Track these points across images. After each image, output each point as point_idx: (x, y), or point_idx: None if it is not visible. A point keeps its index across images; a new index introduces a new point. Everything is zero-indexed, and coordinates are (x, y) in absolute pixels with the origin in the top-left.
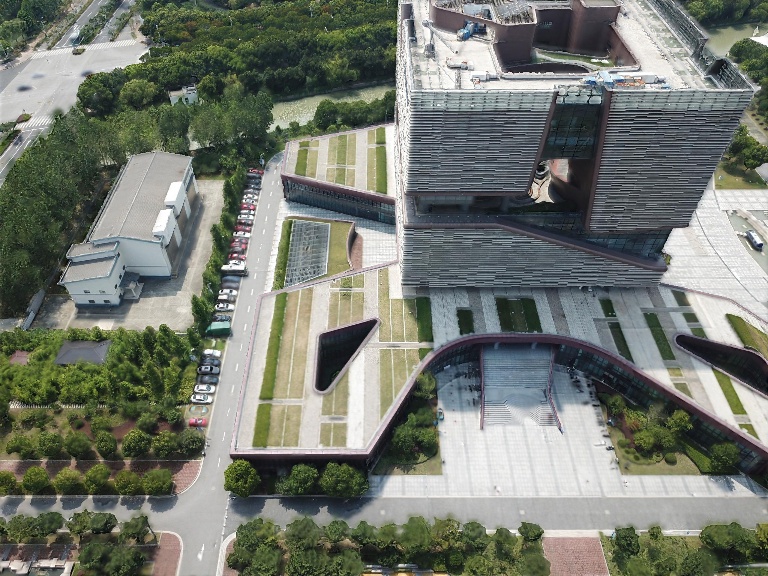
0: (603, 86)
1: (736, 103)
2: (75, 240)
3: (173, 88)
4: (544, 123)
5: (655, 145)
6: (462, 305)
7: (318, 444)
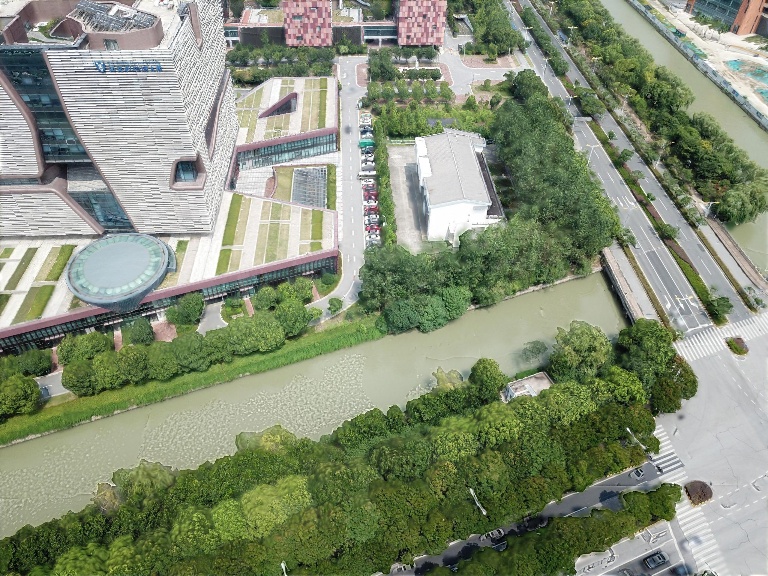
0: None
1: None
2: (515, 197)
3: None
4: None
5: None
6: None
7: (295, 80)
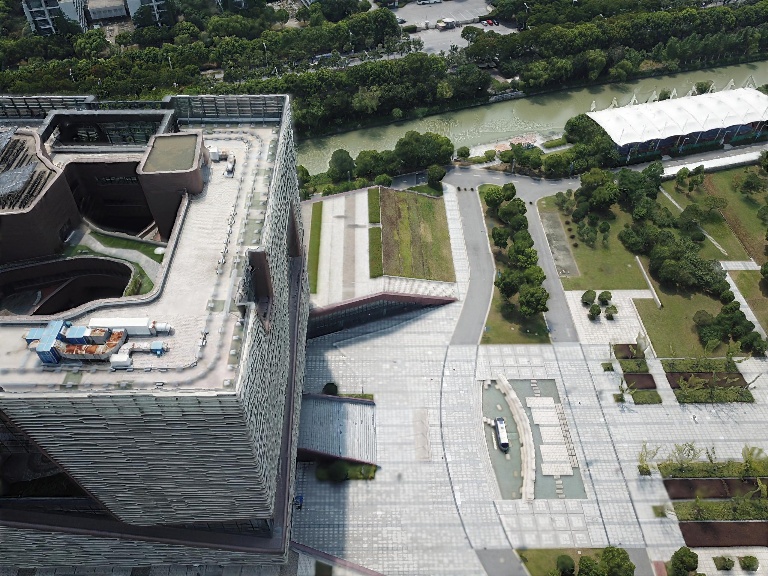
0: None
1: (217, 407)
2: None
3: None
4: None
5: (131, 449)
6: None
7: None
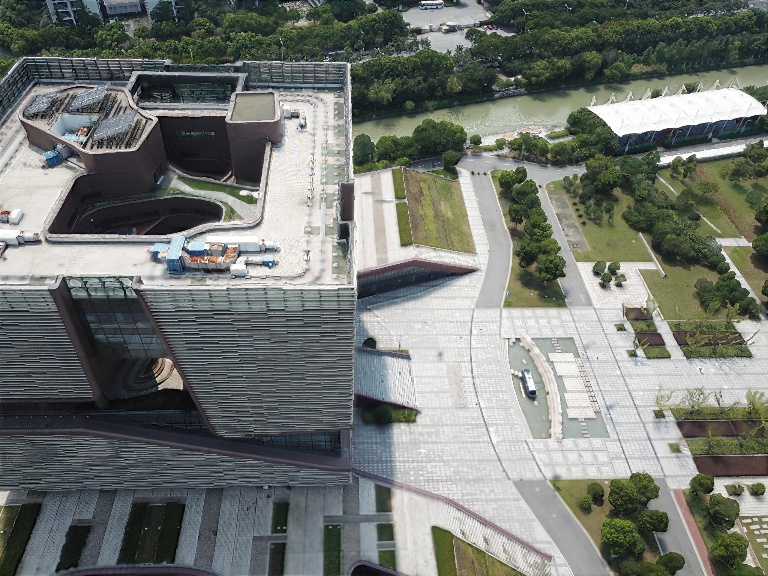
0: (132, 278)
1: (335, 302)
2: None
3: None
4: (62, 325)
5: (247, 348)
6: (82, 516)
7: None
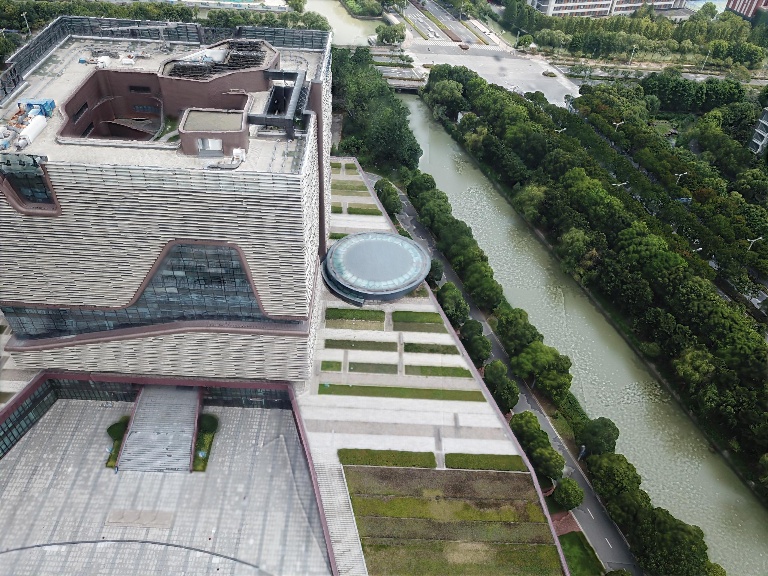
0: None
1: None
2: None
3: (478, 113)
4: None
5: None
6: None
7: None
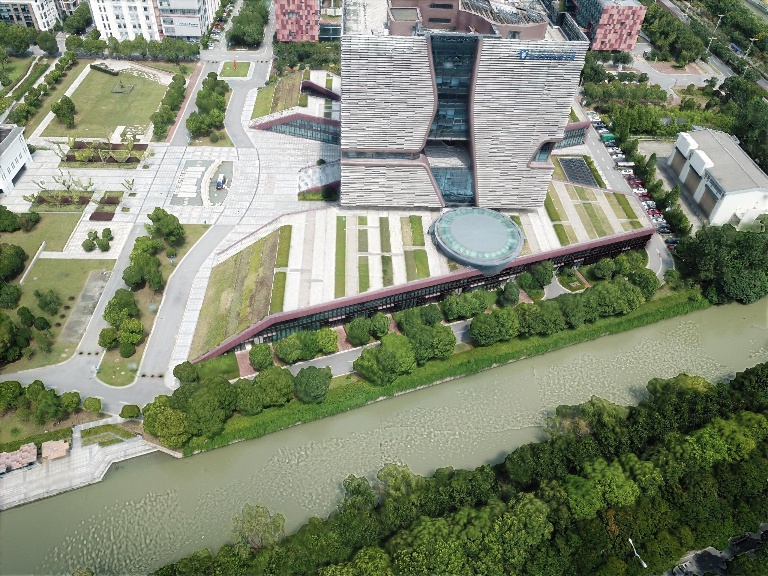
0: None
1: None
2: None
3: None
4: None
5: None
6: None
7: None
